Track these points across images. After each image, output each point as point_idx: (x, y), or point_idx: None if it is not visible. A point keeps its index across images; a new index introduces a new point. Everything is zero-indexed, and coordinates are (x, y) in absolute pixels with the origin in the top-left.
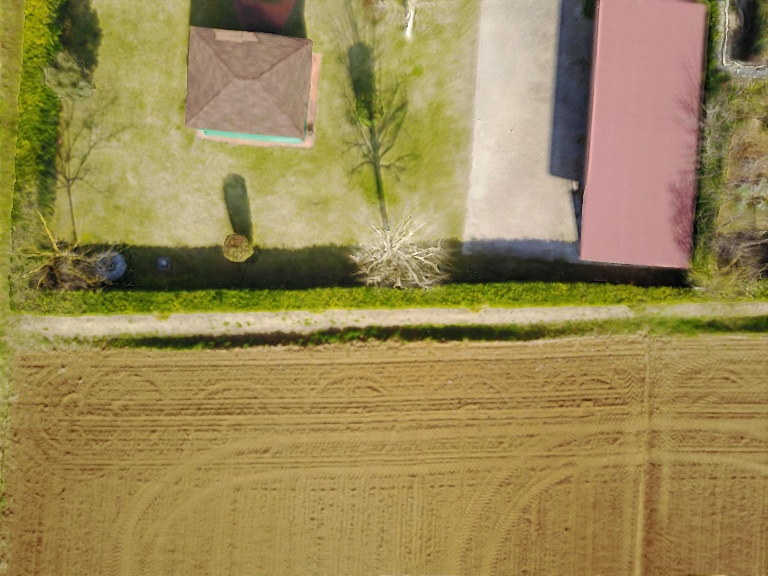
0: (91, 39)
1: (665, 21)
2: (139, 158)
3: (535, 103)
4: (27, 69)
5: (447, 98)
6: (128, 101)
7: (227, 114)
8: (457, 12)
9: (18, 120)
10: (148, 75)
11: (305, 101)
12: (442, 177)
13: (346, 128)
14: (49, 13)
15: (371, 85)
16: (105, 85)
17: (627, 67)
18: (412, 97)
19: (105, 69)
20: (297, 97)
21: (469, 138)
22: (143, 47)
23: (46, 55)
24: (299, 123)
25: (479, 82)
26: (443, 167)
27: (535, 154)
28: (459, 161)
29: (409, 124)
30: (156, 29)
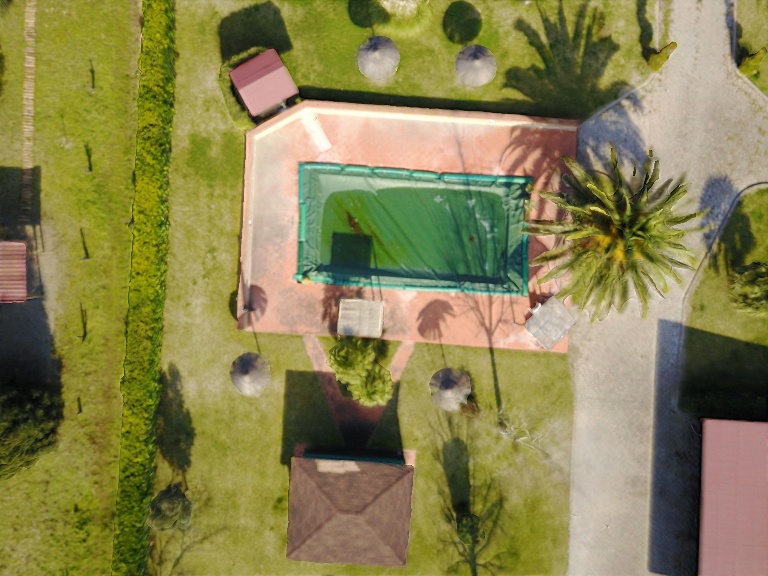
0: (183, 438)
1: (767, 447)
2: (232, 560)
3: (630, 497)
4: (123, 487)
5: (541, 493)
6: (221, 502)
7: (329, 546)
8: (550, 407)
9: (114, 542)
10: (241, 475)
11: (407, 529)
12: (538, 575)
13: (440, 525)
14: (145, 429)
15: (465, 481)
16: (198, 486)
17: (731, 497)
18: (506, 493)
19: (198, 470)
20: (399, 526)
21: (565, 534)
22: (236, 447)
23: (142, 472)
24: (401, 552)
25: (573, 476)
26: (539, 564)
27: (631, 550)
28: (555, 558)
29: (504, 520)
30: (249, 429)
